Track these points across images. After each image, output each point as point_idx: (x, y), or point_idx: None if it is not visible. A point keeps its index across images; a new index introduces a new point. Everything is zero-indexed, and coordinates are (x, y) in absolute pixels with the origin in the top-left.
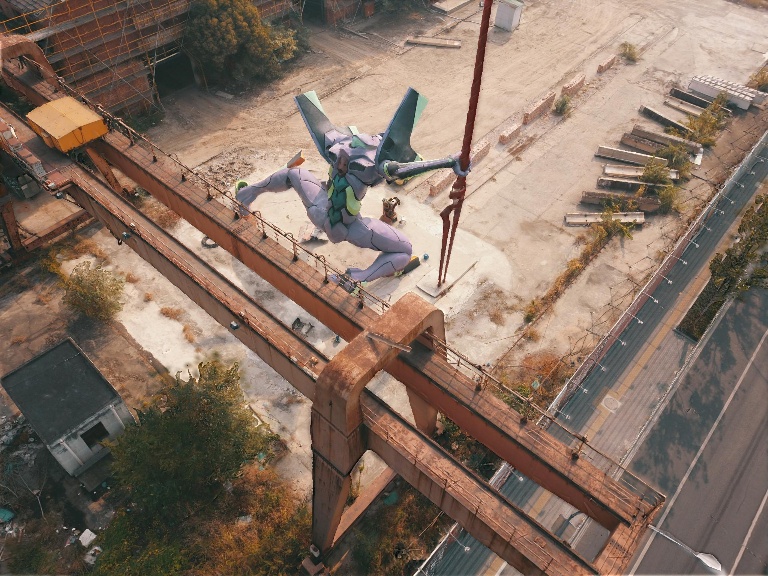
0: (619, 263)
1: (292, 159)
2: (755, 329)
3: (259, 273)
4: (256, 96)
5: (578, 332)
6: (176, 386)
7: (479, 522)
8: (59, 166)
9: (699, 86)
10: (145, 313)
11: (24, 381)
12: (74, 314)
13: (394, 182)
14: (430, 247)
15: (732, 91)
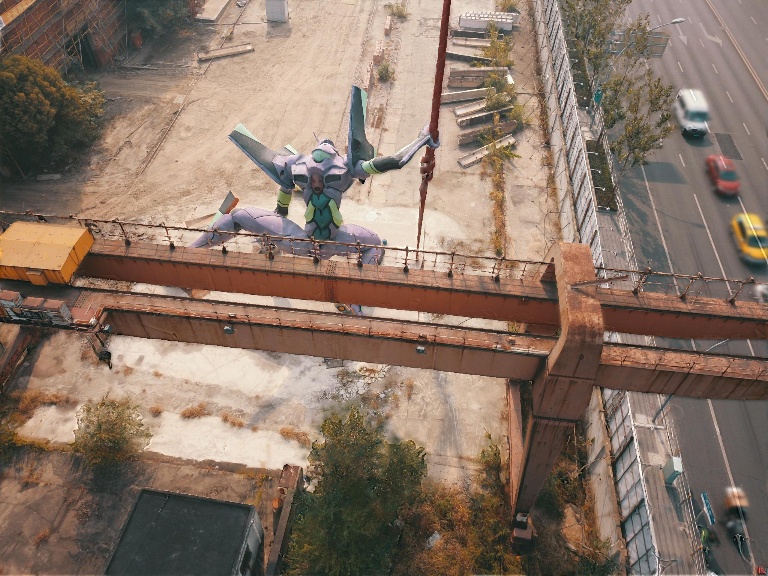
0: (523, 180)
1: (224, 204)
2: (639, 186)
3: (363, 303)
4: (87, 165)
5: (539, 245)
6: (284, 468)
7: (724, 381)
8: (68, 301)
9: (468, 22)
10: (166, 427)
11: (133, 559)
12: (85, 473)
13: (301, 191)
14: (380, 233)
15: (495, 19)
